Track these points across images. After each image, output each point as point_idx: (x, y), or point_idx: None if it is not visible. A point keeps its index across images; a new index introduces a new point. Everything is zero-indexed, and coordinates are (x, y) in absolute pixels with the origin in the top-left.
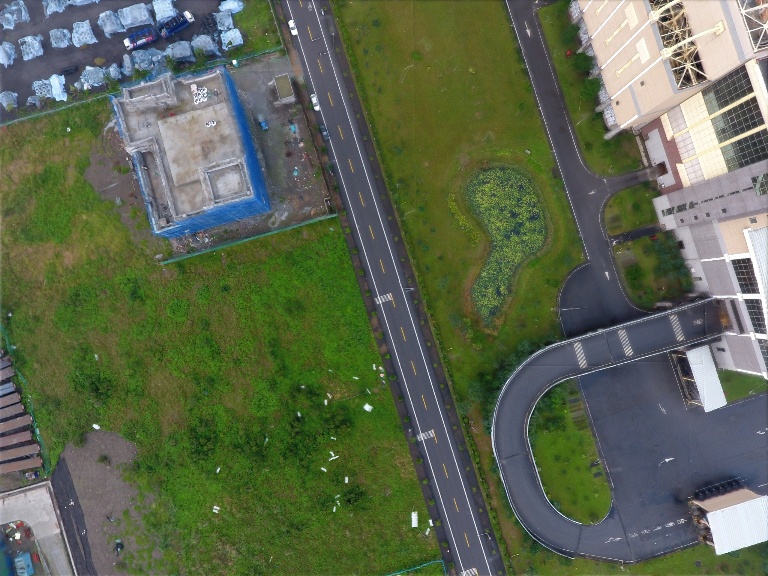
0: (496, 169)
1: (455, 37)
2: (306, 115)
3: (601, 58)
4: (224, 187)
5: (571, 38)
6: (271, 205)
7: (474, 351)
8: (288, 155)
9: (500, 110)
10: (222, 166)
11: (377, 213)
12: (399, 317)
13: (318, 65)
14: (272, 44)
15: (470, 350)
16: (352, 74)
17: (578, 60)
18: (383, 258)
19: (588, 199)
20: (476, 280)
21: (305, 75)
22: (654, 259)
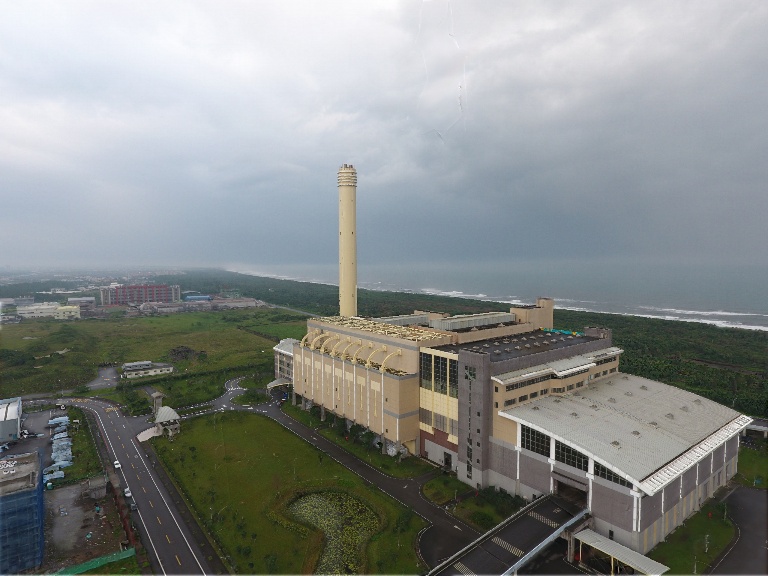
0: (312, 494)
1: (259, 448)
2: (115, 496)
3: (364, 422)
4: (1, 491)
5: (342, 426)
6: (43, 565)
7: None
8: (84, 527)
9: (305, 467)
10: (9, 477)
11: (186, 545)
12: None
13: (136, 477)
14: (94, 473)
15: None
16: (169, 475)
17: (351, 429)
18: None
19: (404, 491)
20: (317, 567)
21: (121, 483)
22: (490, 507)
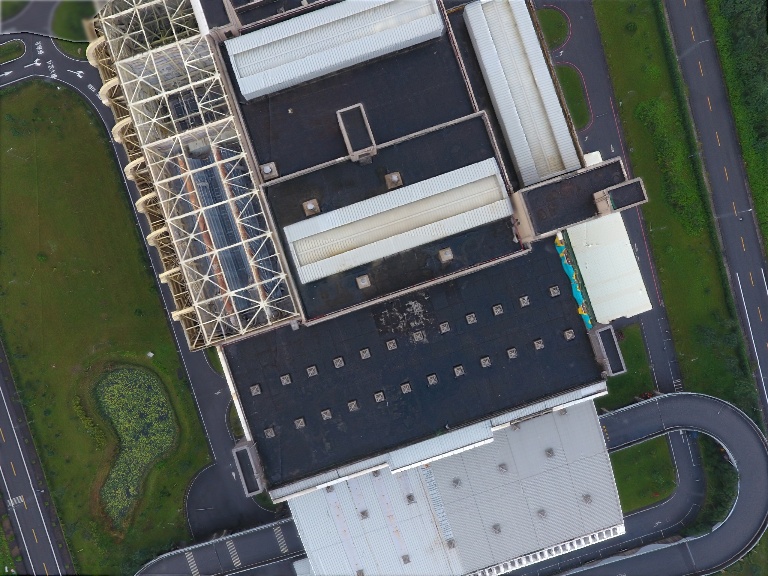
0: (124, 369)
1: (80, 237)
2: None
3: None
4: None
5: None
6: None
7: (101, 554)
8: None
9: (126, 311)
10: None
11: (7, 415)
12: (31, 519)
13: None
14: None
15: (98, 553)
16: None
17: None
18: (14, 460)
19: (214, 399)
20: (105, 481)
21: None
22: None
